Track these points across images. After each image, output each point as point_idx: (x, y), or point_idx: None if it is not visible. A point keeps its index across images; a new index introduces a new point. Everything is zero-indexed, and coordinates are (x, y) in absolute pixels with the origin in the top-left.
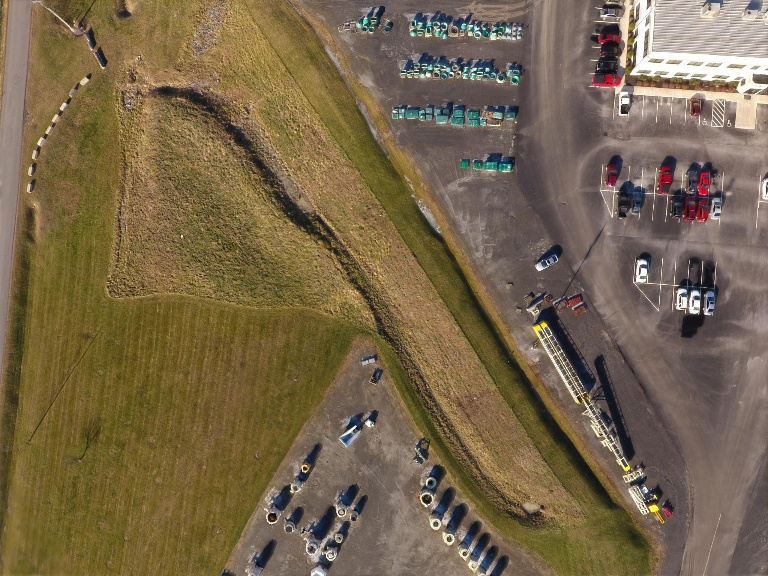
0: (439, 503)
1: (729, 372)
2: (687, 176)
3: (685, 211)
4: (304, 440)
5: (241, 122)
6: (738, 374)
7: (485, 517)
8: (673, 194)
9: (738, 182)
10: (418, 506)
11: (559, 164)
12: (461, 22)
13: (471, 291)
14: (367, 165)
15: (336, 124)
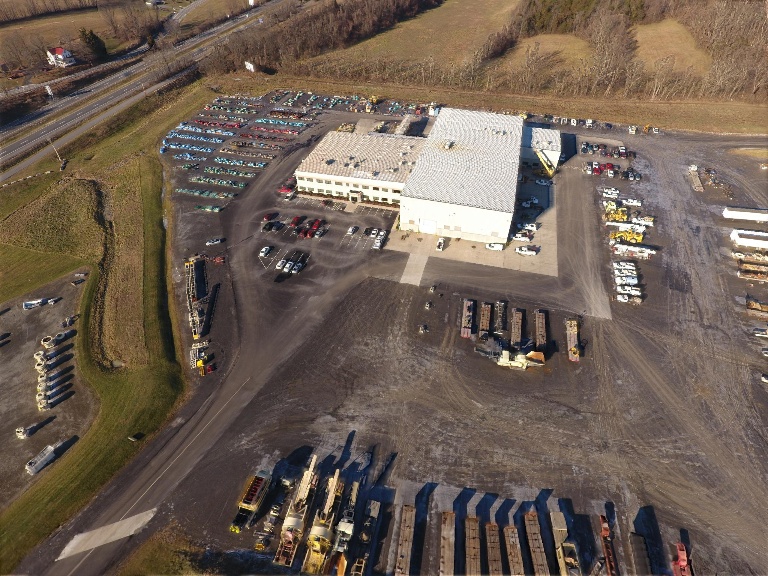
0: (55, 351)
1: (296, 301)
2: None
3: None
4: (2, 305)
5: (106, 191)
6: (301, 302)
7: (80, 363)
8: None
9: (337, 228)
10: None
11: (245, 212)
12: None
13: (164, 250)
14: (149, 203)
15: (146, 190)
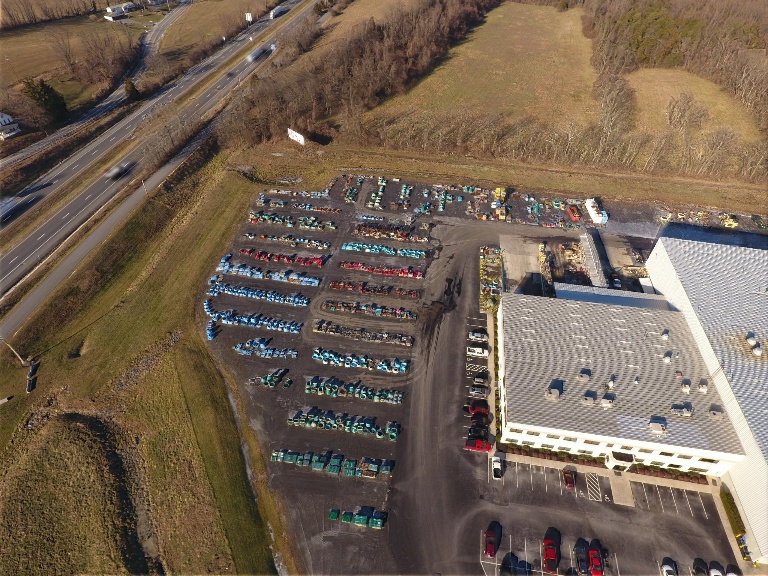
0: None
1: None
2: (574, 553)
3: None
4: None
5: (126, 451)
6: None
7: None
8: (564, 574)
9: (634, 566)
10: None
11: (434, 525)
12: (351, 386)
13: None
14: (230, 506)
15: (214, 461)
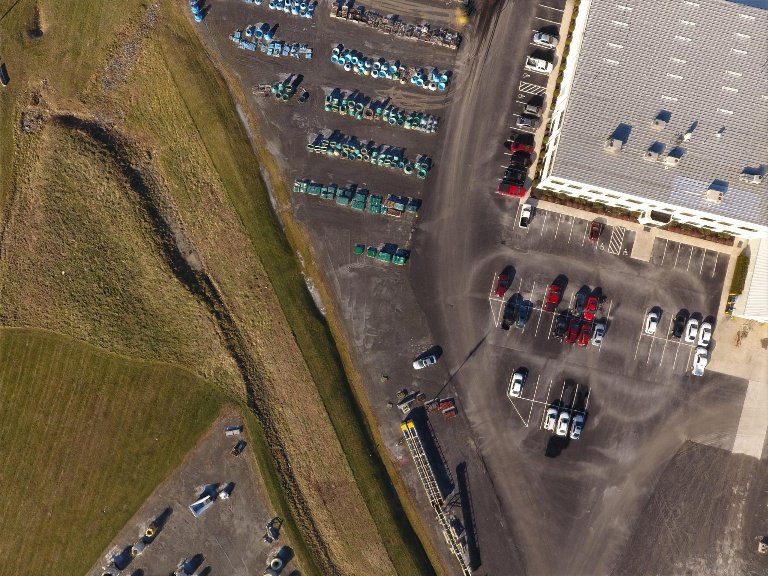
0: None
1: (585, 497)
2: (575, 298)
3: (568, 333)
4: (155, 502)
5: (141, 166)
6: (594, 500)
7: None
8: (560, 313)
9: (624, 311)
10: None
11: (453, 265)
12: (378, 105)
13: (346, 378)
14: (260, 234)
15: (235, 187)
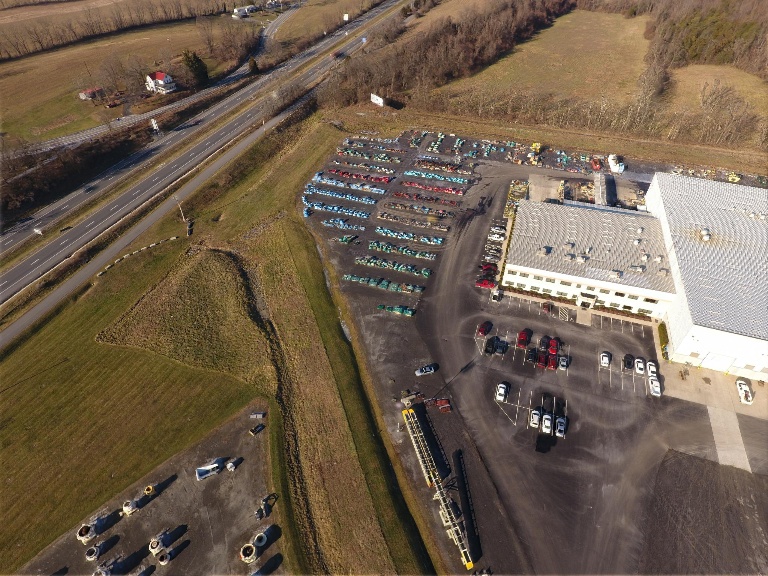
0: (259, 569)
1: (584, 492)
2: (540, 340)
3: (538, 359)
4: (164, 468)
5: (249, 270)
6: (593, 496)
7: None
8: (530, 350)
9: (581, 352)
10: (236, 567)
11: (447, 319)
12: None
13: (360, 380)
14: (315, 296)
15: (306, 275)
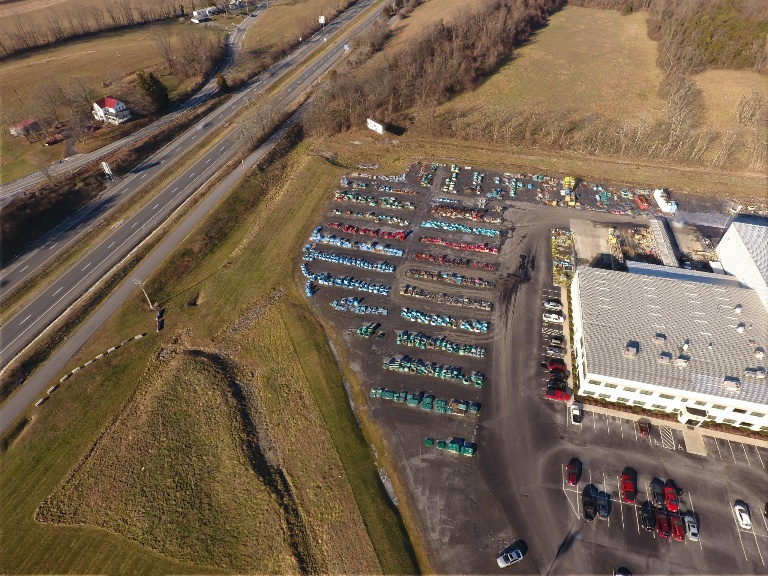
0: None
1: None
2: (650, 488)
3: (657, 525)
4: None
5: (244, 382)
6: None
7: None
8: (641, 505)
9: (708, 505)
10: None
11: (519, 457)
12: (437, 341)
13: None
14: (339, 429)
15: (321, 393)
